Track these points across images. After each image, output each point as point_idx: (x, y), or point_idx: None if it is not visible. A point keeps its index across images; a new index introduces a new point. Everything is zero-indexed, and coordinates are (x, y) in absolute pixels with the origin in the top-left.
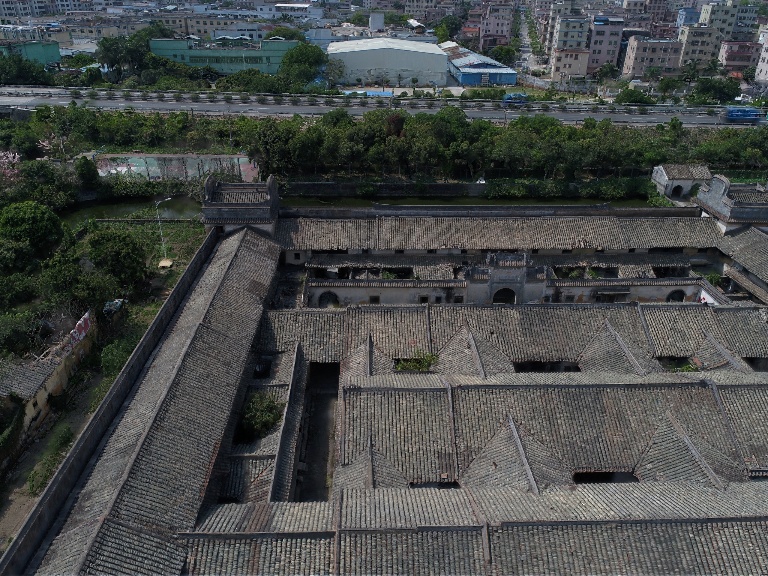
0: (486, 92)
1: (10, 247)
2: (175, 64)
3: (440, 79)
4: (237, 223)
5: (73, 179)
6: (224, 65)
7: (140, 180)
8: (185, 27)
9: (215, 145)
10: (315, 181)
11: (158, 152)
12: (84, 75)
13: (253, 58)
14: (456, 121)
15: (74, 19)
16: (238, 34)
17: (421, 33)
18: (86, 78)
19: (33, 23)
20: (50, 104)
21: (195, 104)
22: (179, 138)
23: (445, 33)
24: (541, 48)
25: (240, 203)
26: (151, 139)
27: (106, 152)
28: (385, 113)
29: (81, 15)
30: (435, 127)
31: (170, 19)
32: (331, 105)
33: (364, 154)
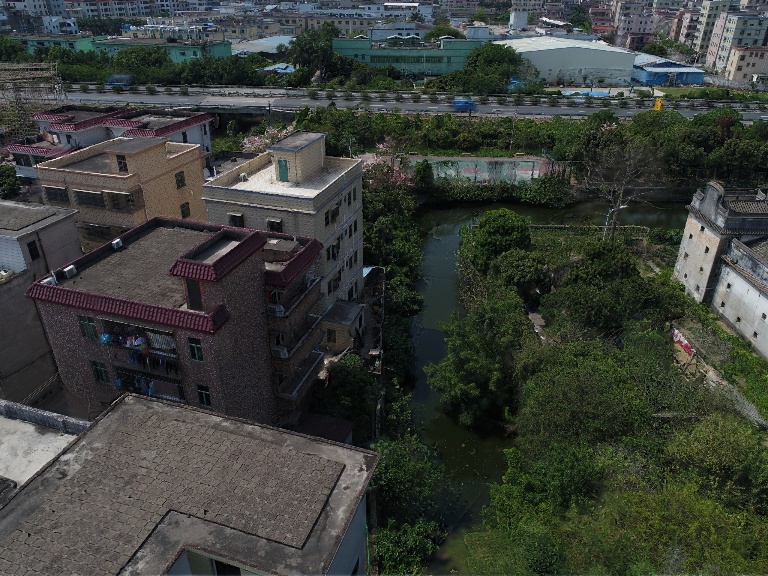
0: (713, 92)
1: (534, 258)
2: (359, 64)
3: (652, 79)
4: (759, 234)
5: (418, 183)
6: (404, 65)
7: (470, 184)
8: (305, 27)
9: (485, 147)
10: (643, 186)
11: (434, 154)
12: (294, 75)
13: (434, 58)
14: (737, 123)
15: (207, 19)
16: (395, 33)
17: (567, 31)
18: (297, 78)
19: (188, 23)
20: (298, 105)
21: (437, 105)
22: (451, 140)
23: (588, 31)
24: (691, 46)
25: (767, 213)
26: (423, 141)
27: (382, 154)
28: (662, 114)
29: (200, 15)
30: (761, 130)
31: (290, 19)
32: (572, 106)
33: (705, 158)
